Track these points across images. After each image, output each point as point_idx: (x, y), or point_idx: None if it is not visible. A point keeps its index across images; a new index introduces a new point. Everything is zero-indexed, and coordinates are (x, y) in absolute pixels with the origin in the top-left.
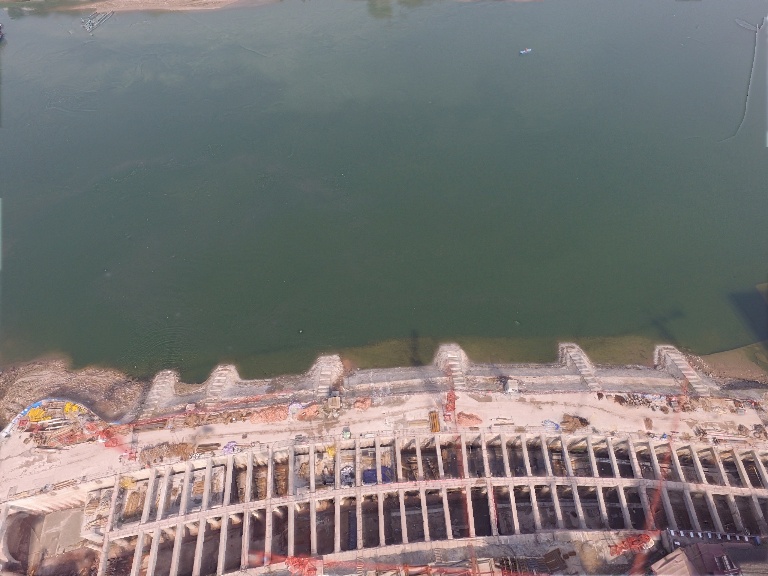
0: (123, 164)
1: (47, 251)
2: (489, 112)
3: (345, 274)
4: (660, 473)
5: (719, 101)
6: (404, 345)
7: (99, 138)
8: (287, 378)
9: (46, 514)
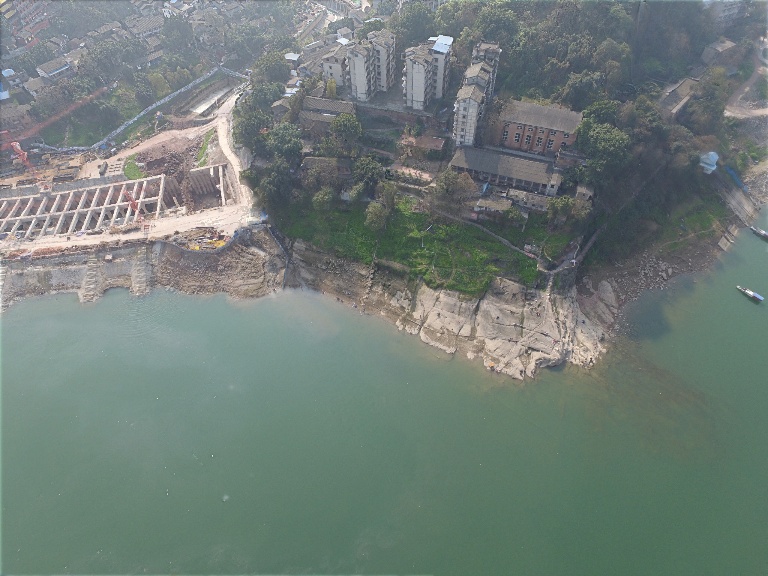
0: None
1: (302, 427)
2: None
3: None
4: None
5: None
6: None
7: None
8: (37, 293)
9: None
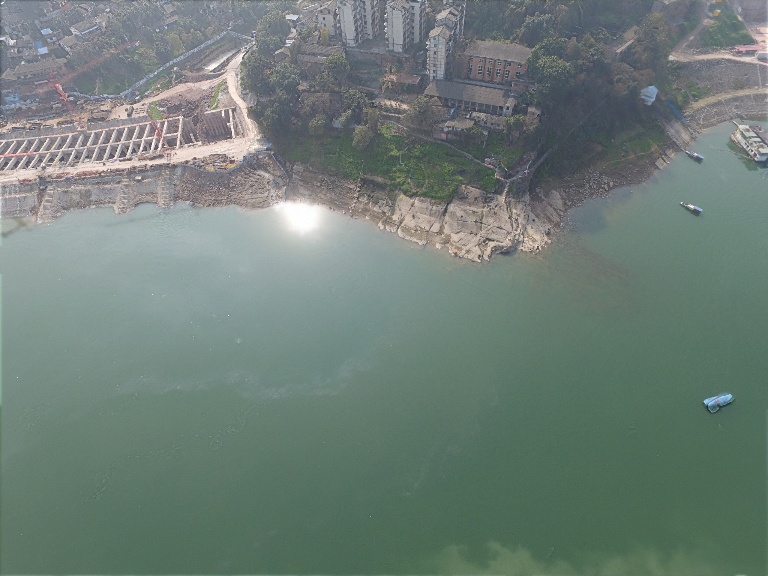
0: (251, 451)
1: (299, 295)
2: None
3: None
4: None
5: None
6: None
7: (316, 533)
8: (79, 207)
9: None
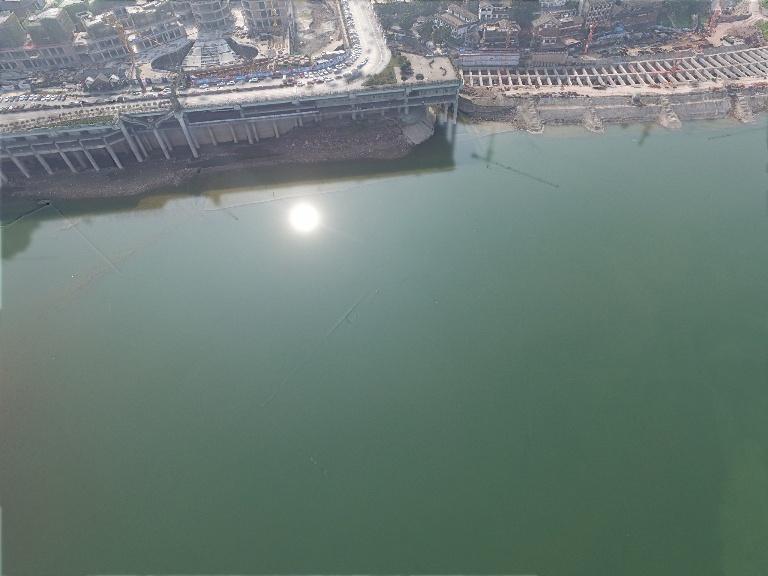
0: None
1: None
2: (767, 398)
3: None
4: (559, 78)
5: (353, 440)
6: (705, 129)
7: None
8: (766, 111)
9: None
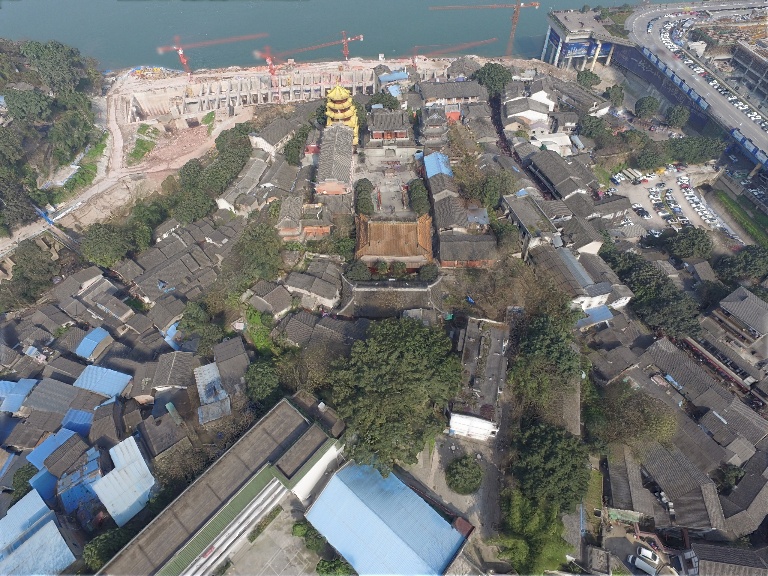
0: None
1: (123, 33)
2: None
3: (300, 37)
4: None
5: None
6: (331, 59)
7: None
8: None
9: (148, 116)
